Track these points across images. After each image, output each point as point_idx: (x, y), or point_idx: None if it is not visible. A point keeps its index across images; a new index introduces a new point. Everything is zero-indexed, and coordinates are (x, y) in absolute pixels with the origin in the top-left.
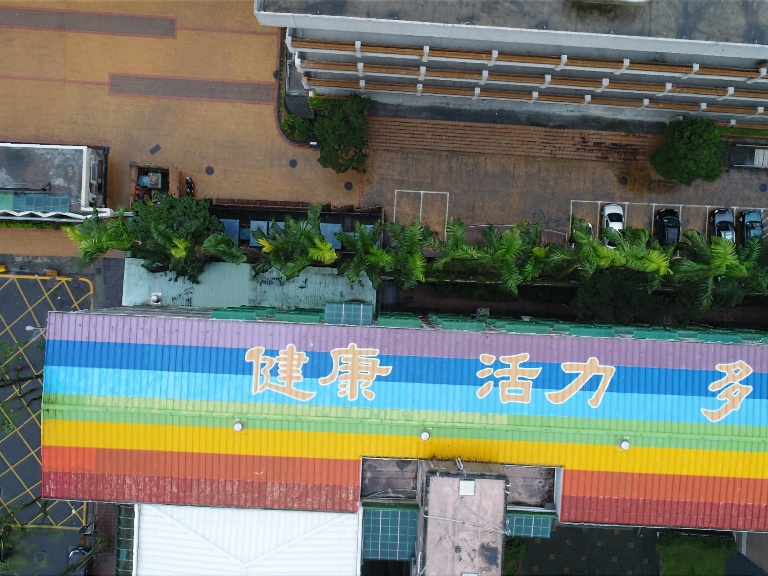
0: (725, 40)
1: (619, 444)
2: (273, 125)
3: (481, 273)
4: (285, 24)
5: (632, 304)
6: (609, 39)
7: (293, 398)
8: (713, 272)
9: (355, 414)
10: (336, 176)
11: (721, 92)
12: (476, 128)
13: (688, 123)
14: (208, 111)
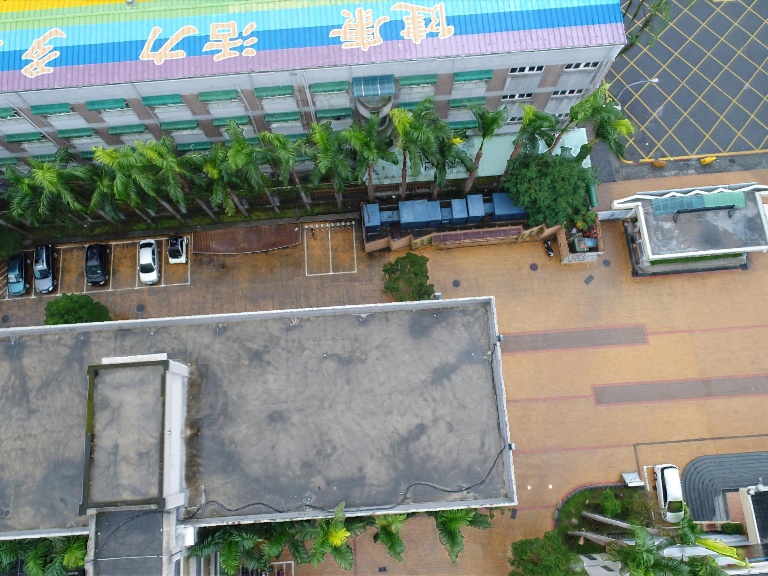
0: (43, 341)
1: (135, 1)
2: None
3: (269, 210)
4: None
5: None
6: None
7: (409, 4)
8: None
9: None
10: None
11: None
12: None
13: None
14: (546, 321)
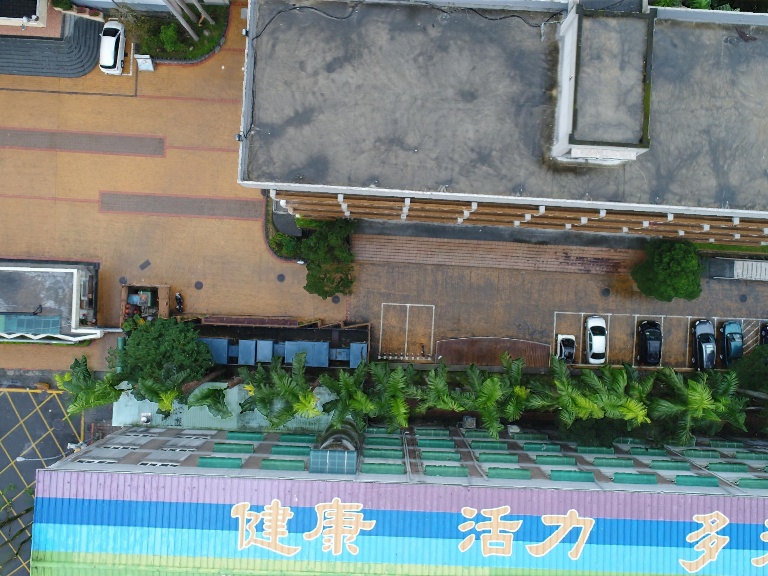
0: (697, 201)
1: None
2: (261, 241)
3: None
4: (268, 187)
5: (614, 425)
6: (584, 204)
7: (278, 553)
8: (691, 413)
9: (339, 568)
10: None
11: (697, 229)
12: (460, 244)
13: (667, 247)
14: (197, 227)
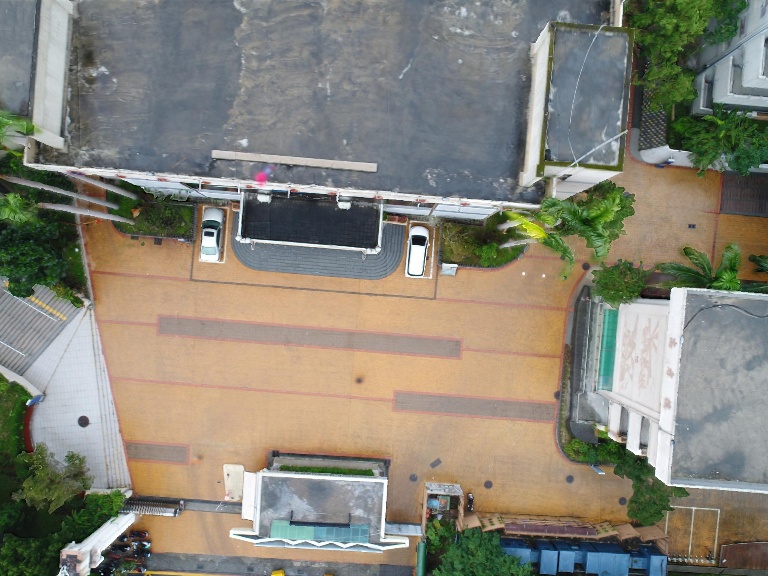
0: None
1: None
2: (552, 442)
3: None
4: None
5: None
6: None
7: None
8: None
9: None
10: (611, 492)
11: None
12: None
13: None
14: (489, 428)
